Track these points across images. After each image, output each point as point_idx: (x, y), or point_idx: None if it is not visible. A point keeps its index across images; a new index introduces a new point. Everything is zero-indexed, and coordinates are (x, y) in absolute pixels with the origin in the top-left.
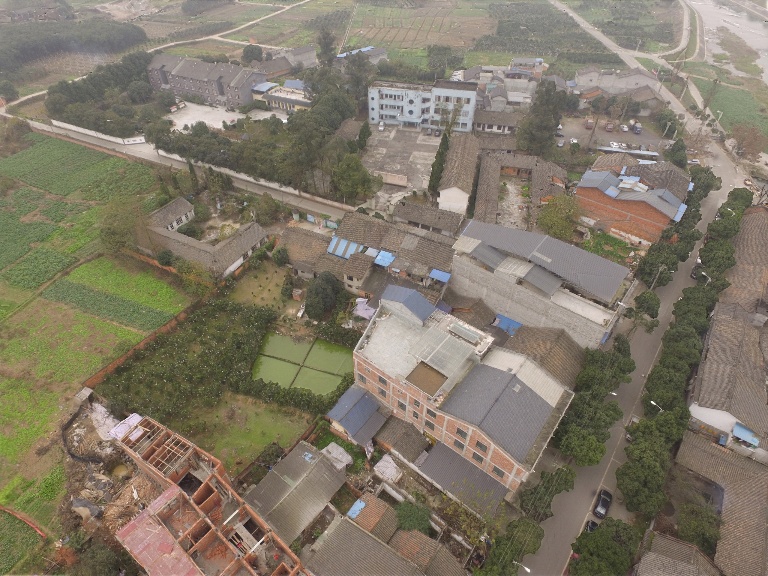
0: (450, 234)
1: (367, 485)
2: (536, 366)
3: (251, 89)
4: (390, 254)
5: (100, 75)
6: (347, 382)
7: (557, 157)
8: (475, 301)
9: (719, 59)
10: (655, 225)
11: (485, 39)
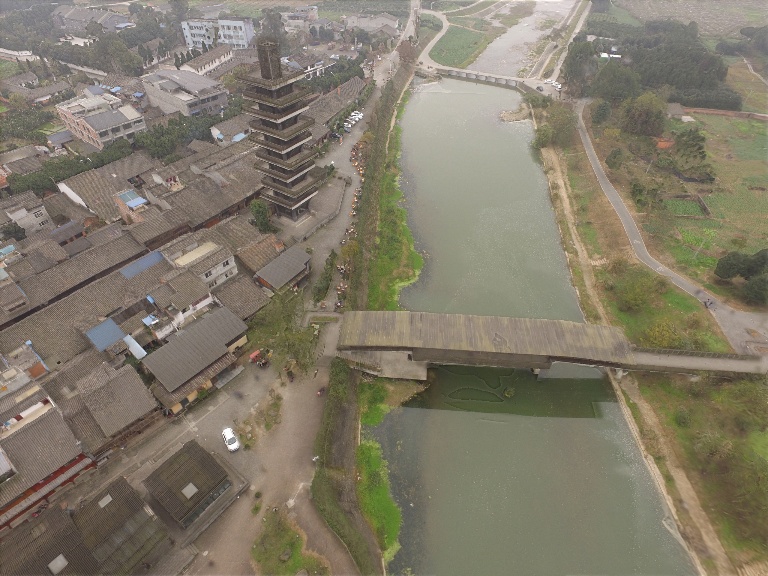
0: None
1: None
2: (132, 107)
3: (114, 26)
4: (120, 87)
5: (14, 16)
6: None
7: None
8: (155, 107)
9: (495, 17)
10: None
11: (323, 3)
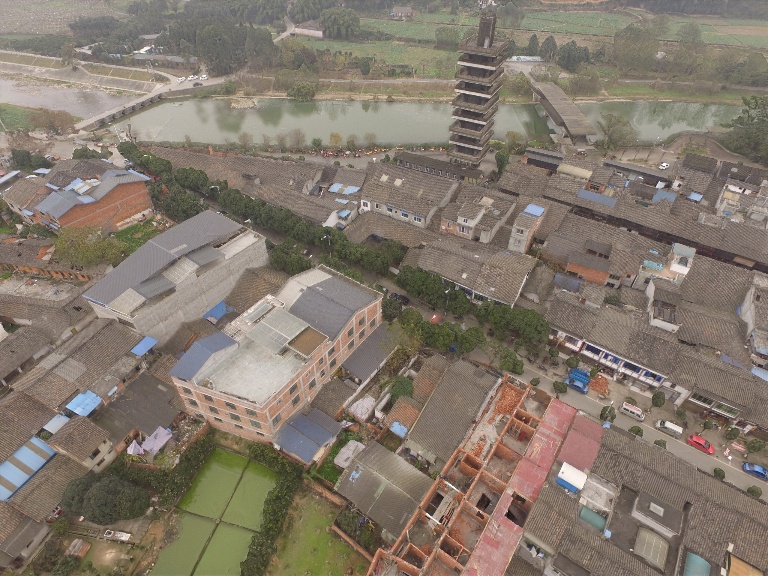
0: (49, 347)
1: (378, 422)
2: (299, 276)
3: None
4: (79, 396)
5: None
6: (265, 450)
7: None
8: (184, 328)
9: None
10: (140, 195)
11: None
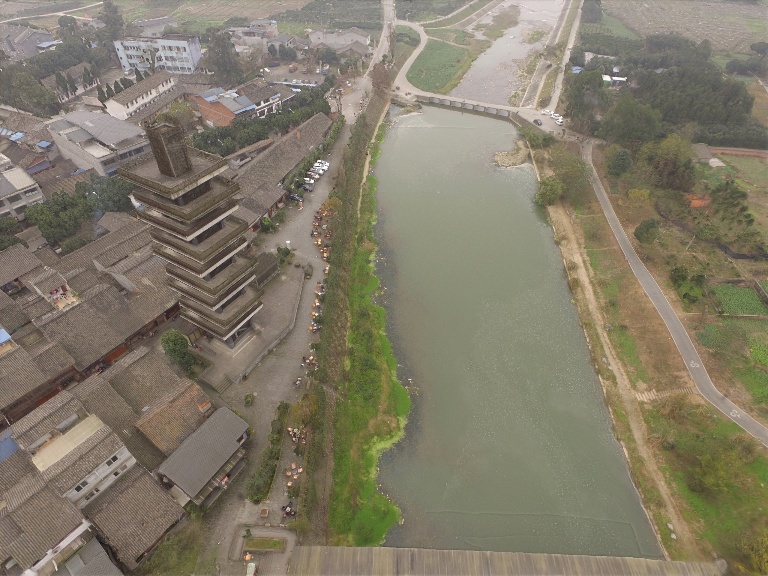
0: None
1: None
2: (23, 171)
3: (36, 46)
4: (22, 134)
5: None
6: None
7: None
8: (65, 160)
9: (478, 27)
10: None
11: (286, 13)
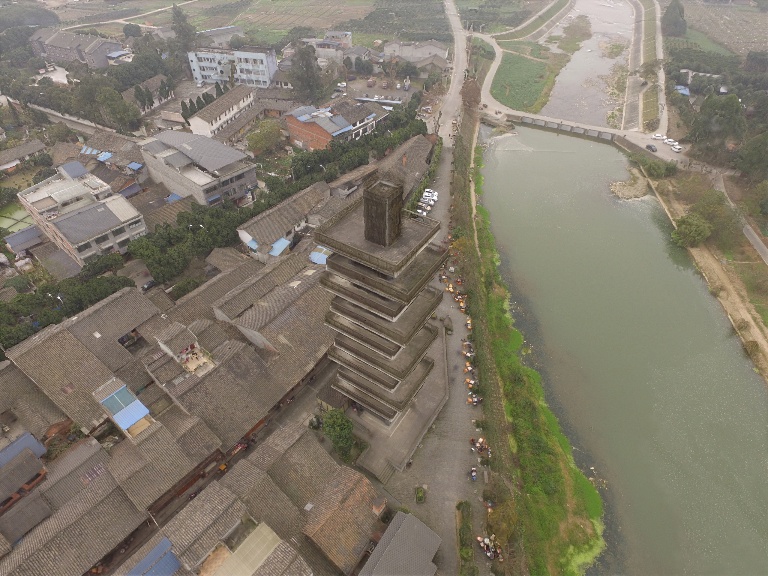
0: None
1: (2, 270)
2: (125, 200)
3: (105, 55)
4: (110, 154)
5: None
6: None
7: (319, 104)
8: (157, 184)
9: (550, 39)
10: (327, 141)
11: (349, 22)
